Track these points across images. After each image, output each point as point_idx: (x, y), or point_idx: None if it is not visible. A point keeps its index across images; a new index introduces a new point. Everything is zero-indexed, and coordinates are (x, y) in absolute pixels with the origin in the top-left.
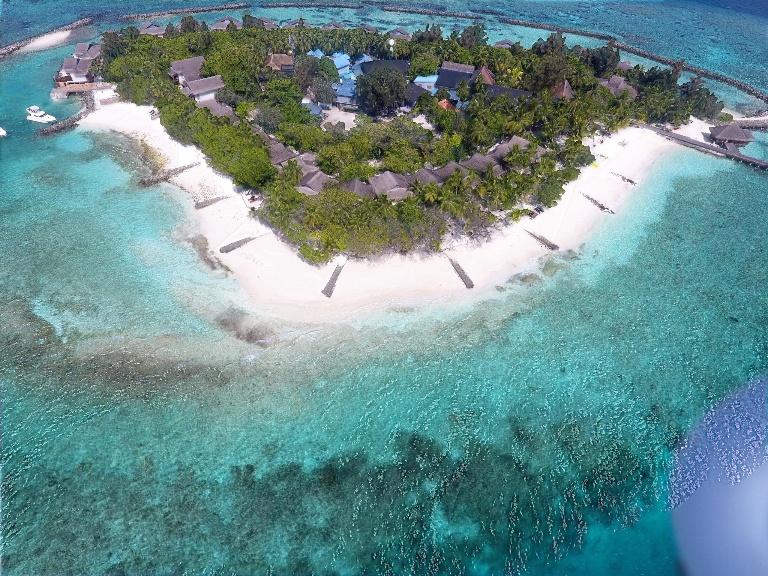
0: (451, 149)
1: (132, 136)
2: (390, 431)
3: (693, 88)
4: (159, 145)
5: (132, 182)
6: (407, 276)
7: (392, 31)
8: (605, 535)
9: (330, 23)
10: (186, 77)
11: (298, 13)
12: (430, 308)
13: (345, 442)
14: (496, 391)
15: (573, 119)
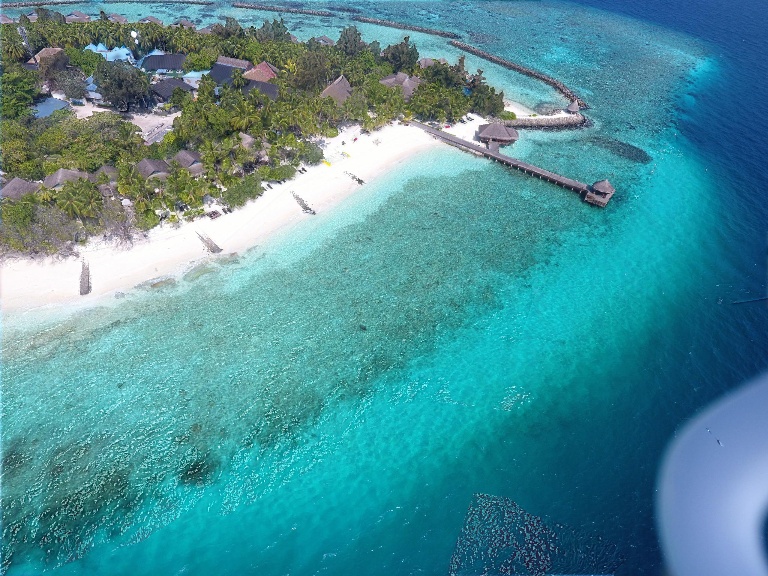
0: None
1: None
2: None
3: (476, 85)
4: None
5: None
6: (20, 281)
7: (208, 26)
8: None
9: (145, 18)
10: None
11: (138, 8)
12: (20, 317)
13: None
14: (23, 409)
15: None
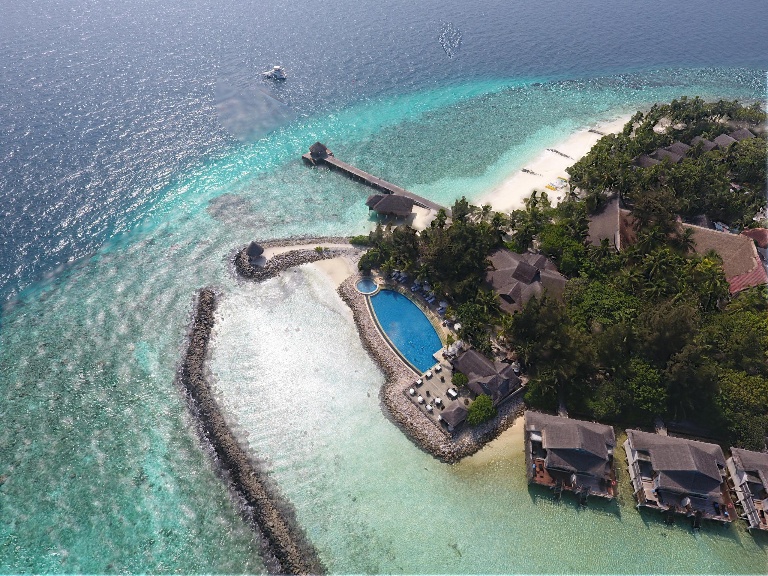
0: None
1: None
2: None
3: None
4: None
5: None
6: None
7: None
8: None
9: None
10: None
11: None
12: None
13: None
14: None
15: None
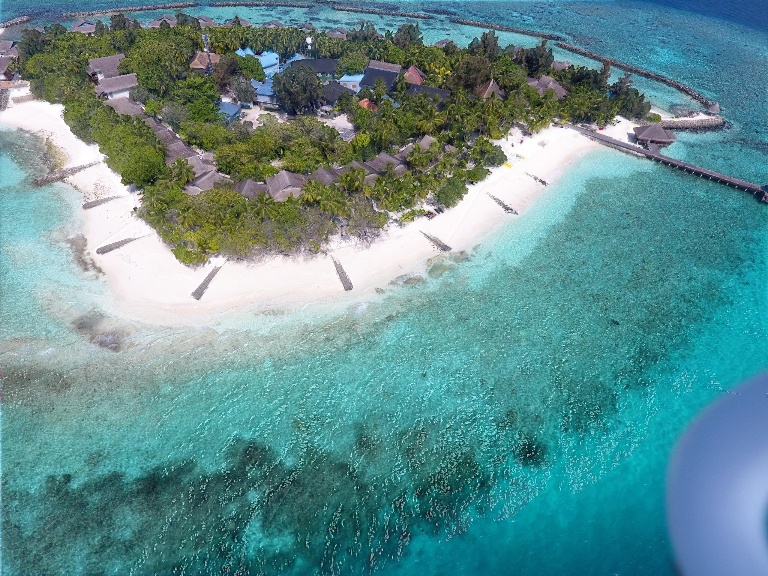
0: (361, 149)
1: (38, 135)
2: (226, 438)
3: (621, 88)
4: (64, 144)
5: (25, 181)
6: (285, 278)
7: (332, 30)
8: (427, 547)
9: (270, 22)
10: (104, 75)
11: (246, 12)
12: (301, 311)
13: (176, 450)
14: (349, 396)
15: (486, 119)
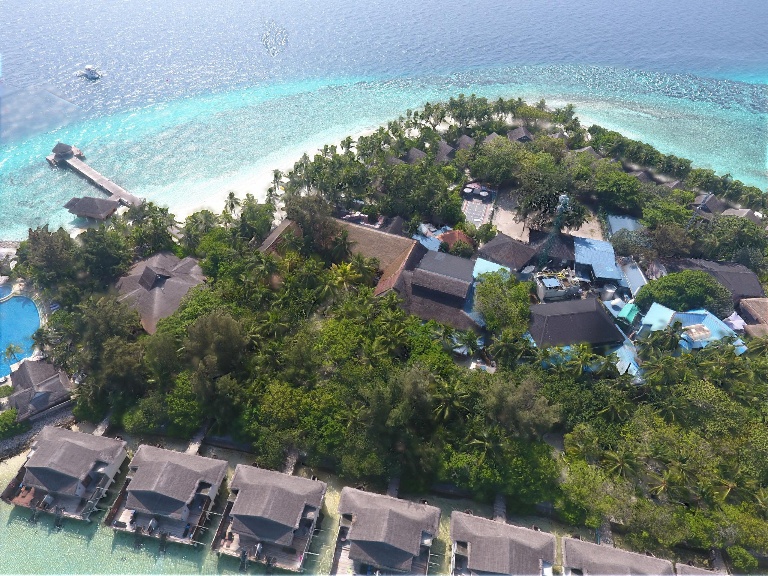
0: None
1: None
2: None
3: None
4: None
5: None
6: None
7: None
8: None
9: None
10: None
11: None
12: None
13: None
14: None
15: None
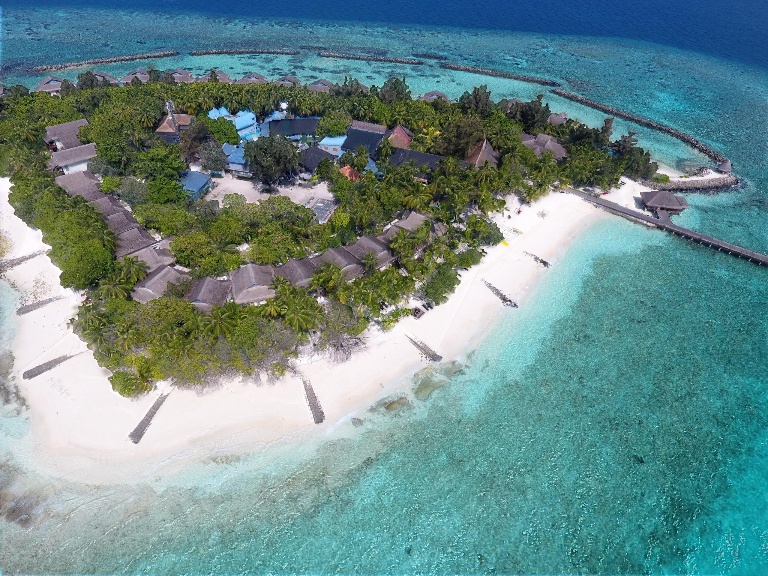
0: (340, 229)
1: None
2: None
3: (625, 147)
4: (8, 227)
5: None
6: (244, 407)
7: (315, 82)
8: None
9: (250, 74)
10: (63, 143)
11: (227, 61)
12: (261, 455)
13: None
14: None
15: None
